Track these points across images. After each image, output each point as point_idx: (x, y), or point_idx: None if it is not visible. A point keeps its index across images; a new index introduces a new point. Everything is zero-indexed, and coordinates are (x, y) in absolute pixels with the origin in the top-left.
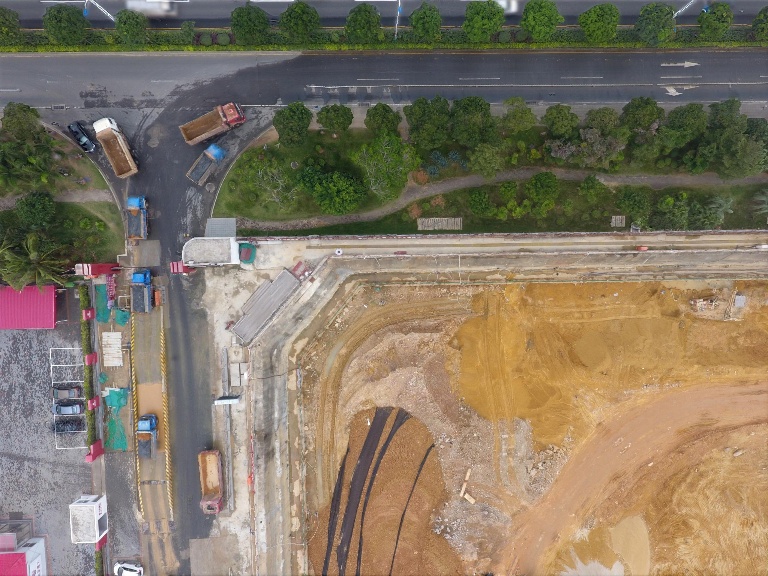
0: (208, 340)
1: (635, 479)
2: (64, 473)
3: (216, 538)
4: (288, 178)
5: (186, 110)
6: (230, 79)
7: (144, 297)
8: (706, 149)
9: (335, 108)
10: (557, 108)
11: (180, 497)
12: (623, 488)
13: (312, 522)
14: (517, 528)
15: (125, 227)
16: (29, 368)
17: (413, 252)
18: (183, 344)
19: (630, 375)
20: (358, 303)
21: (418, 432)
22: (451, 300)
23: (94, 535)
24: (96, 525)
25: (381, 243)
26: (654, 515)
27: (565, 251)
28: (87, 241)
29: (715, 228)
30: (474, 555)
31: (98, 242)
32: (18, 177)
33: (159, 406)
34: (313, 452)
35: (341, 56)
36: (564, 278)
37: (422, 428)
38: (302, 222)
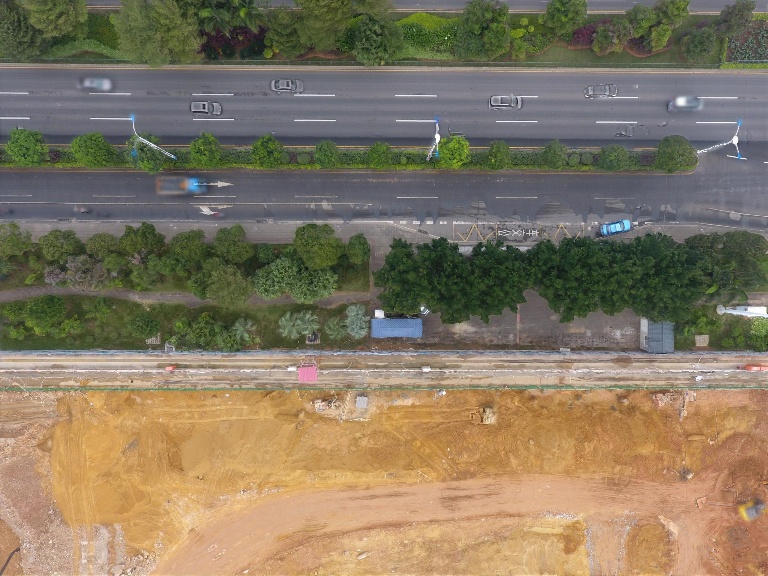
0: None
1: None
2: None
3: None
4: None
5: None
6: None
7: None
8: (191, 279)
9: None
10: (48, 235)
11: None
12: None
13: None
14: None
15: None
16: None
17: None
18: None
19: (229, 479)
20: None
21: (3, 536)
22: (36, 403)
23: None
24: None
25: None
26: None
27: (97, 368)
28: None
29: (236, 350)
30: None
31: None
32: None
33: None
34: None
35: None
36: (139, 386)
37: (7, 532)
38: None
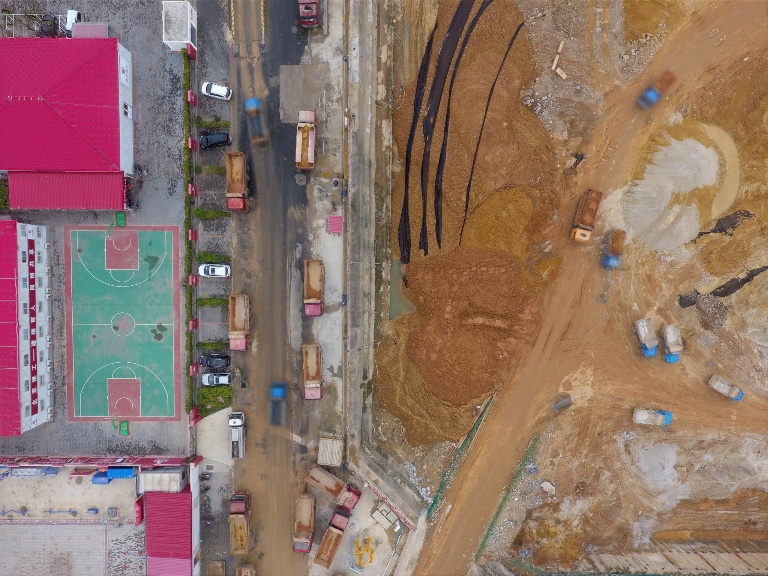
0: None
1: (730, 74)
2: None
3: (307, 66)
4: None
5: None
6: None
7: None
8: None
9: None
10: None
11: (272, 19)
12: (717, 80)
13: (397, 96)
14: (609, 108)
15: None
16: None
17: None
18: None
19: None
20: None
21: (509, 9)
22: None
23: (186, 34)
24: (189, 24)
25: None
26: (743, 134)
27: None
28: None
29: None
30: (564, 133)
31: None
32: None
33: None
34: (401, 22)
35: None
36: None
37: (513, 5)
38: None
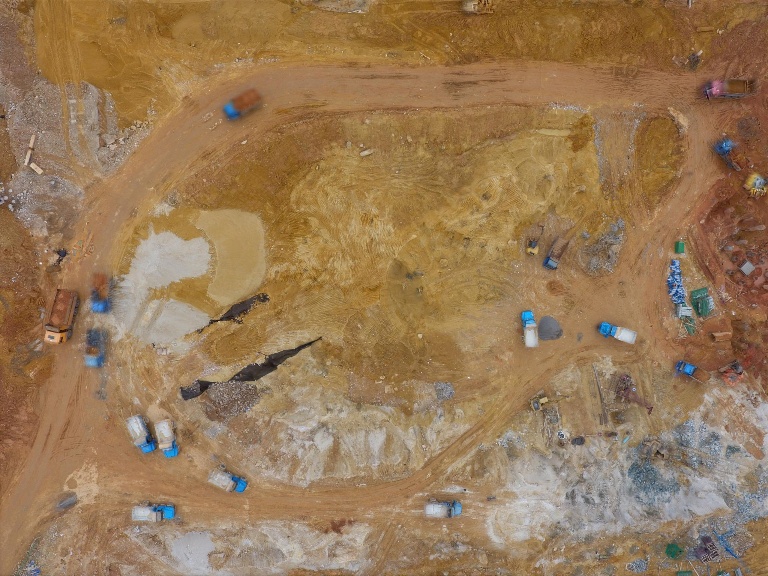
0: None
1: (228, 158)
2: None
3: None
4: None
5: None
6: None
7: None
8: None
9: None
10: None
11: None
12: (213, 166)
13: None
14: (90, 201)
15: None
16: None
17: None
18: None
19: (223, 49)
20: None
21: None
22: None
23: None
24: None
25: None
26: (271, 214)
27: None
28: None
29: None
30: (43, 230)
31: None
32: None
33: None
34: None
35: None
36: None
37: None
38: None
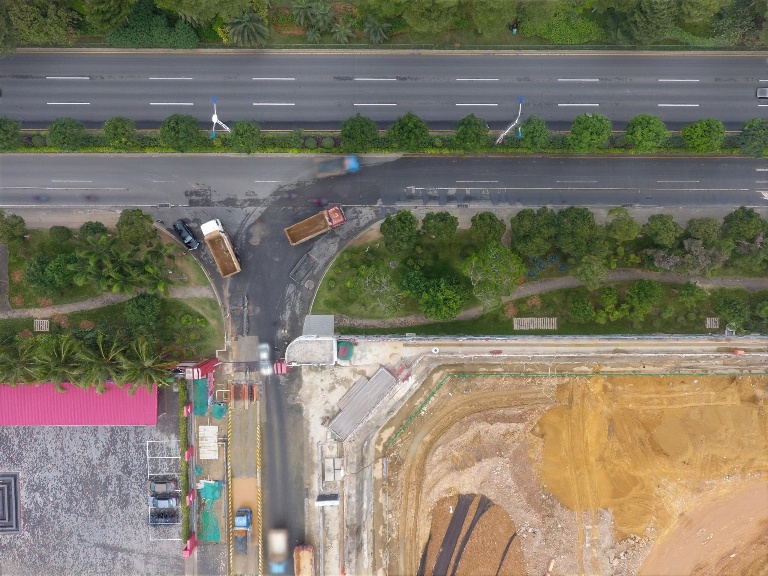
0: (303, 435)
1: (717, 570)
2: (157, 564)
3: None
4: (395, 285)
5: (288, 209)
6: (332, 180)
7: (244, 394)
8: None
9: (442, 217)
10: (661, 219)
11: None
12: None
13: None
14: None
15: (225, 323)
16: (126, 460)
17: (509, 351)
18: (278, 438)
19: (712, 464)
20: (444, 392)
21: (500, 520)
22: (535, 389)
23: None
24: None
25: (477, 342)
26: None
27: (660, 352)
28: (188, 336)
29: None
30: None
31: (198, 337)
32: (133, 283)
33: (253, 499)
34: (396, 539)
35: (441, 158)
36: (651, 371)
37: (504, 516)
38: (399, 320)
